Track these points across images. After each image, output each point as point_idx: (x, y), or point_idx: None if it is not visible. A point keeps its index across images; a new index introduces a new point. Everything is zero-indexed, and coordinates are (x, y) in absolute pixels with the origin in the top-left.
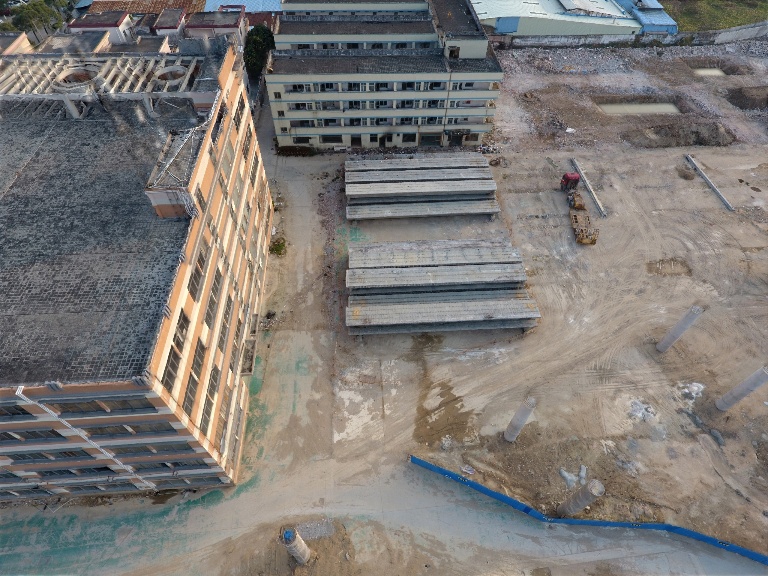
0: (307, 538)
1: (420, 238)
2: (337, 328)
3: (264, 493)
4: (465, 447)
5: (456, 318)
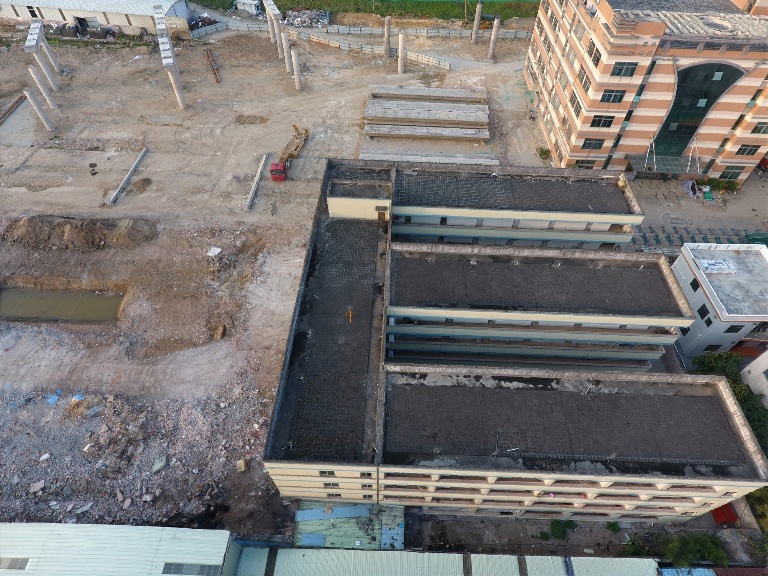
0: (490, 59)
1: (432, 150)
2: (489, 109)
3: (511, 68)
4: (423, 71)
5: (420, 88)
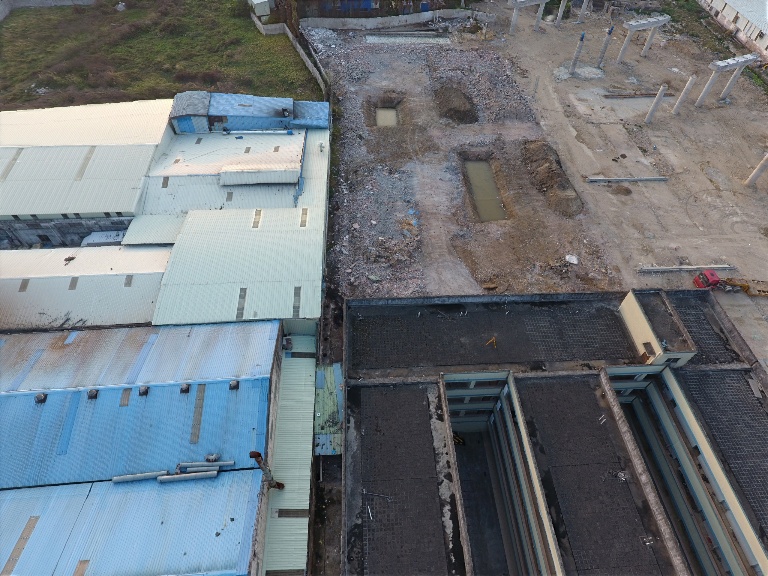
0: None
1: None
2: None
3: None
4: None
5: None
